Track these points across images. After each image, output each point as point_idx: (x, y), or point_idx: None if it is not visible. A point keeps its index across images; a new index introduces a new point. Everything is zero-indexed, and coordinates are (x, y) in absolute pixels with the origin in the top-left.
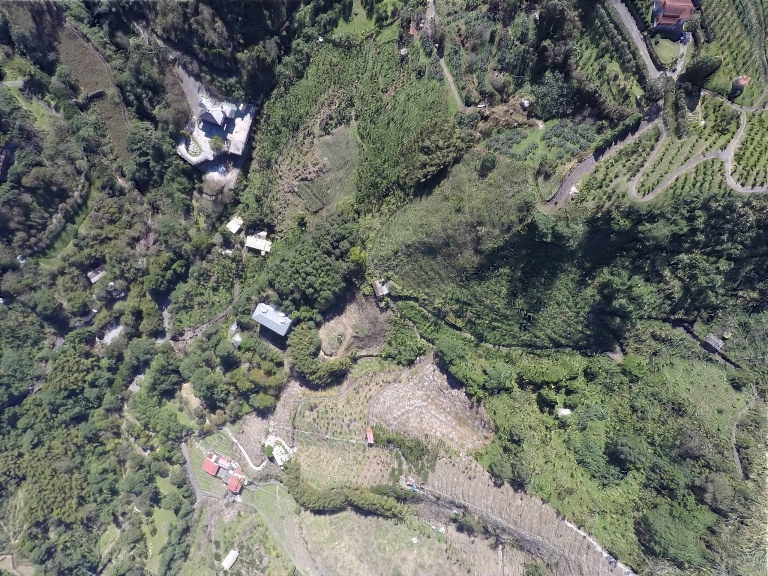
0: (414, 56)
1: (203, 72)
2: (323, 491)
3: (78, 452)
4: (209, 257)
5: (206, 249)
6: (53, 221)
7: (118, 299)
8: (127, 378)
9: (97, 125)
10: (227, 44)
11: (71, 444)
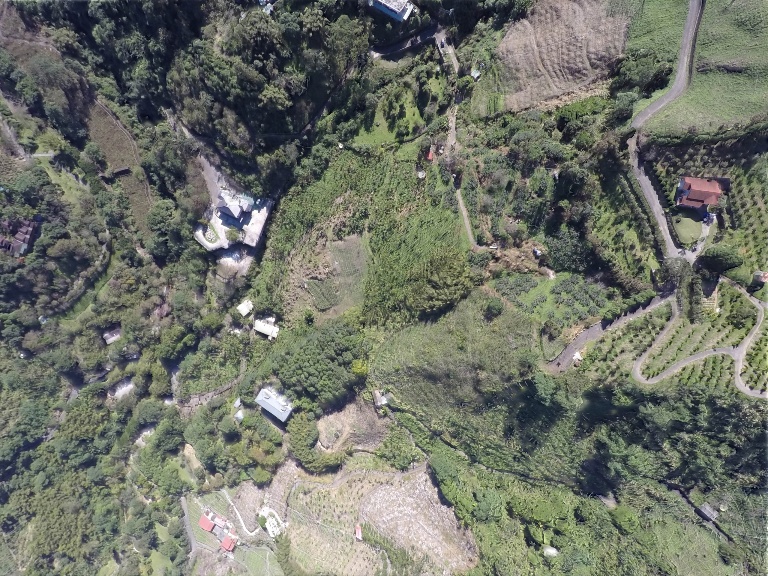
0: (431, 181)
1: (224, 166)
2: (310, 574)
3: (85, 493)
4: (218, 336)
5: (215, 329)
6: (74, 287)
7: (130, 360)
8: (134, 434)
9: (120, 199)
10: (248, 145)
11: (79, 487)
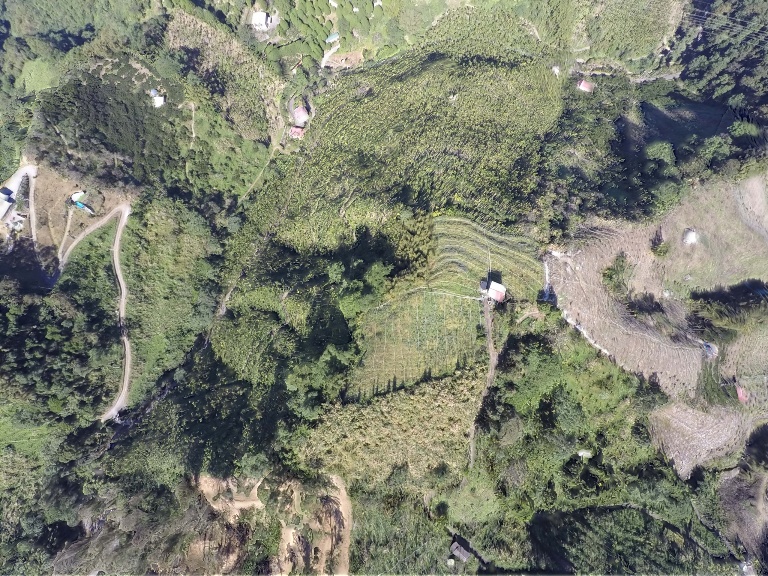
0: None
1: None
2: None
3: None
4: None
5: None
6: None
7: None
8: None
9: None
10: None
11: None
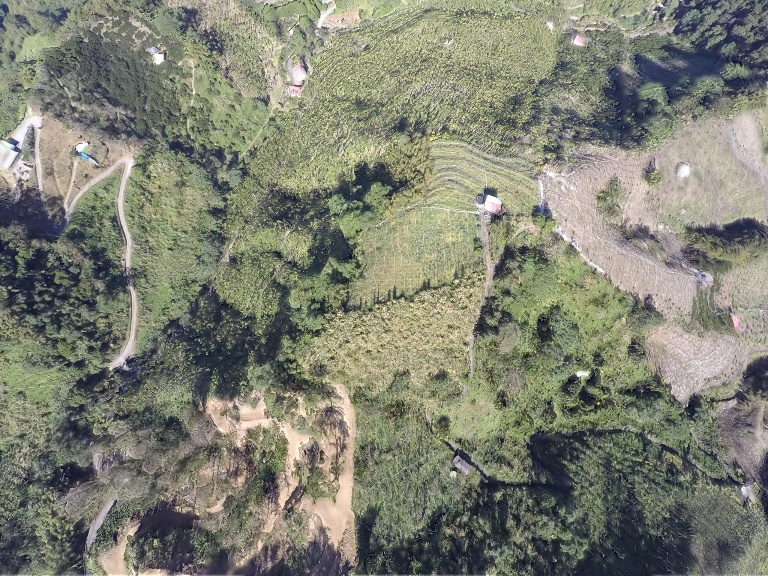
0: None
1: None
2: (766, 254)
3: None
4: None
5: None
6: None
7: None
8: None
9: None
10: None
11: None
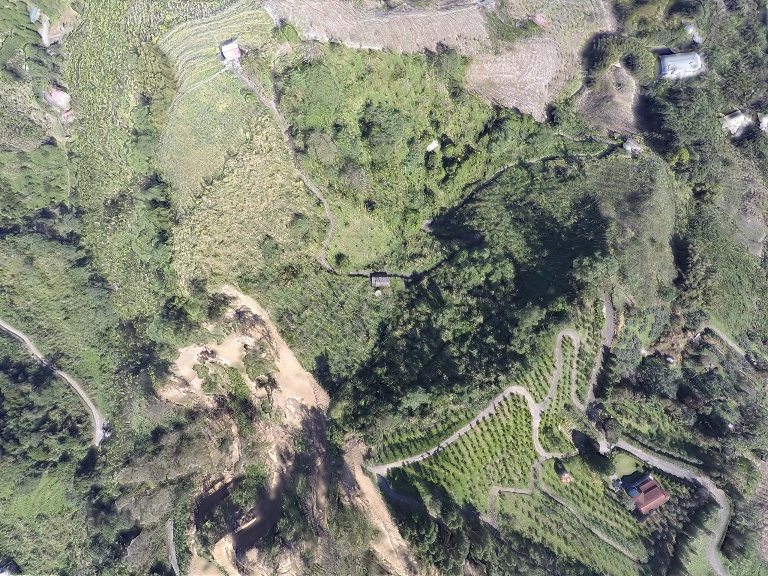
0: (760, 345)
1: None
2: None
3: None
4: (763, 78)
5: None
6: None
7: None
8: None
9: None
10: None
11: None
